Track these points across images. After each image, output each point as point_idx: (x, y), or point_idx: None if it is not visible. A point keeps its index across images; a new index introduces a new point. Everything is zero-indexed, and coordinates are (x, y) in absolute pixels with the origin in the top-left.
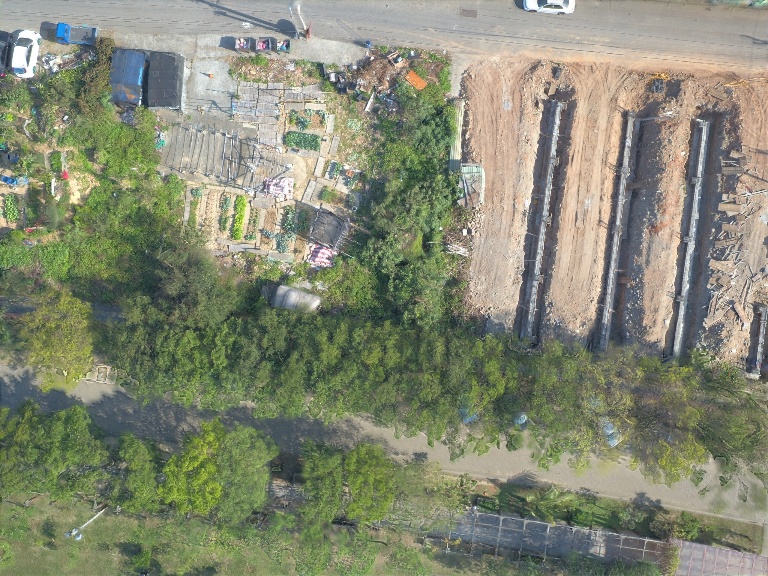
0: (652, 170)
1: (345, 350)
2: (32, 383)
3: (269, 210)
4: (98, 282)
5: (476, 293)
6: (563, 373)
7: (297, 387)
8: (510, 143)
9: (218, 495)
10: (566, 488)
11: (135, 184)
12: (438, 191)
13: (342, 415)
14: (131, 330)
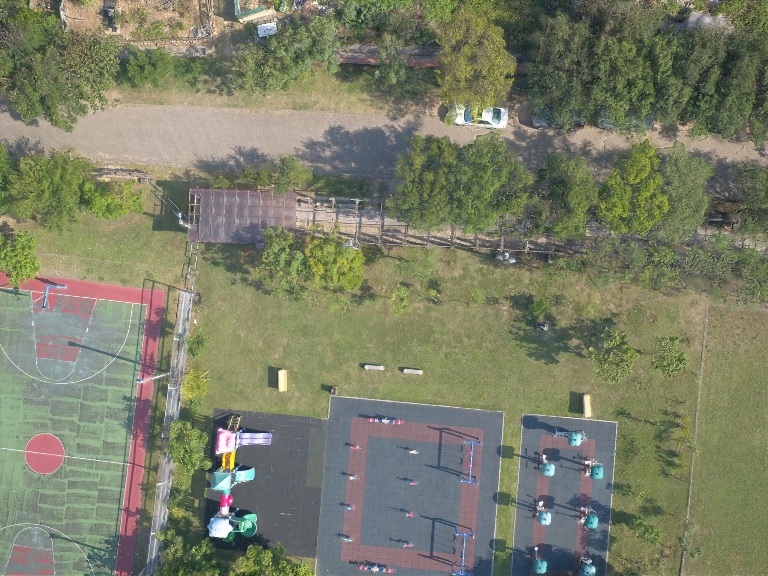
0: None
1: None
2: (413, 132)
3: None
4: None
5: None
6: None
7: (749, 93)
8: None
9: (667, 209)
10: None
11: None
12: None
13: (747, 154)
14: (563, 43)
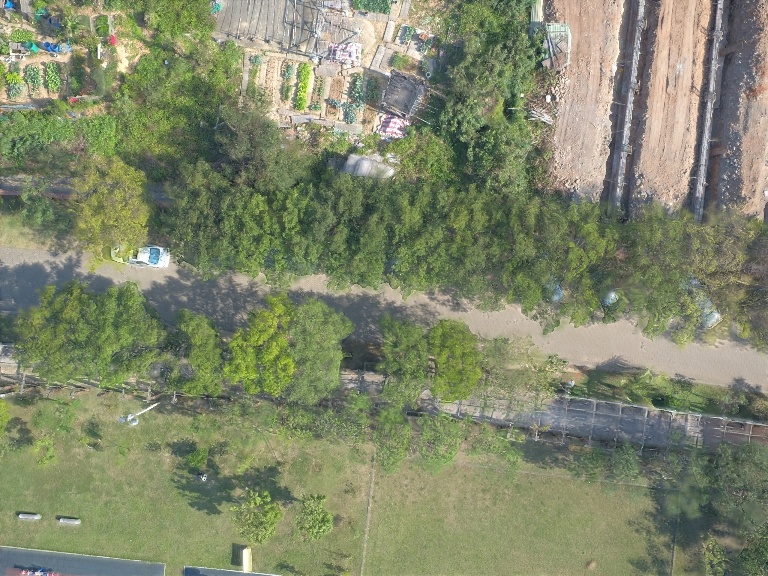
0: (748, 31)
1: (427, 216)
2: (75, 269)
3: (335, 78)
4: (148, 158)
5: (561, 164)
6: (671, 231)
7: (377, 252)
8: (596, 3)
9: (291, 372)
10: (660, 375)
11: (190, 48)
12: (522, 50)
13: (416, 299)
14: (192, 194)
